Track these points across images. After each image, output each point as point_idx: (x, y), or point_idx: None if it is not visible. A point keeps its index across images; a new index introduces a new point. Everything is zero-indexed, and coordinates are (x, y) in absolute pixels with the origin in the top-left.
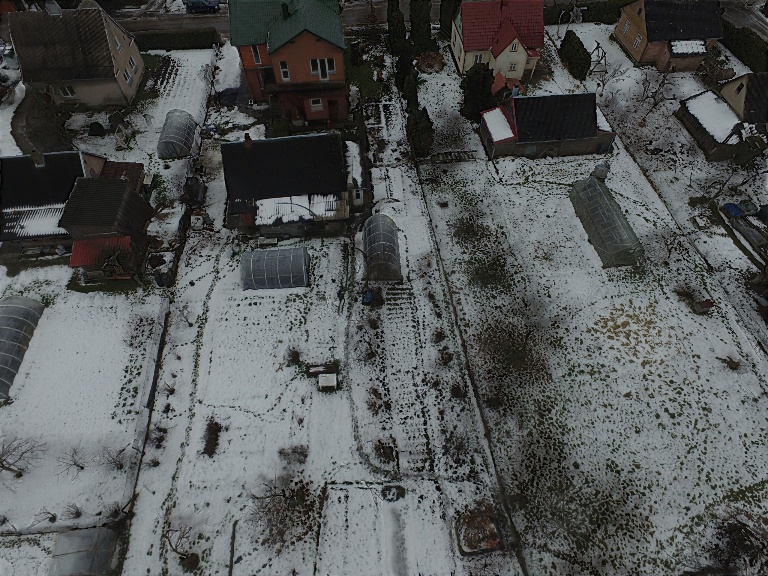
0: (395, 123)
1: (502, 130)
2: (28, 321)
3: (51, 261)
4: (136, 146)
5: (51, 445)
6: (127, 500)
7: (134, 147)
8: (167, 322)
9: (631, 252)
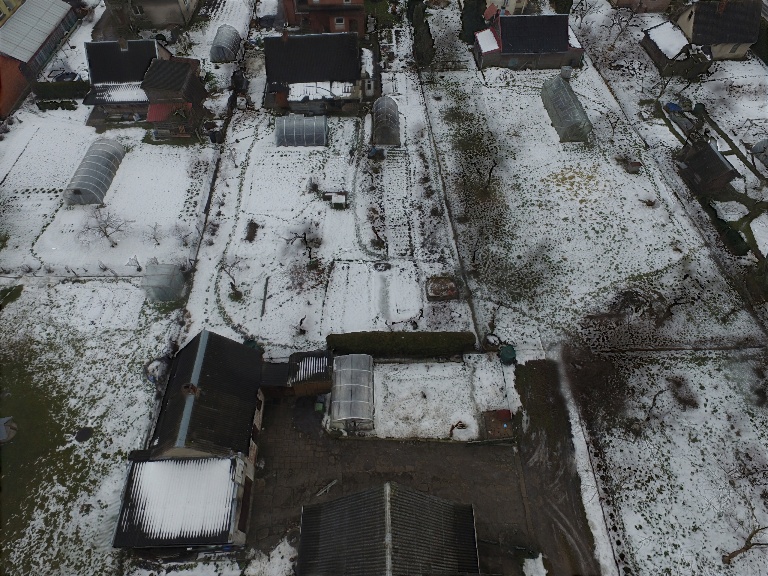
0: (404, 43)
1: (490, 44)
2: (116, 157)
3: (129, 125)
4: (192, 53)
5: (135, 231)
6: (192, 259)
7: (191, 54)
8: (218, 164)
9: (582, 127)
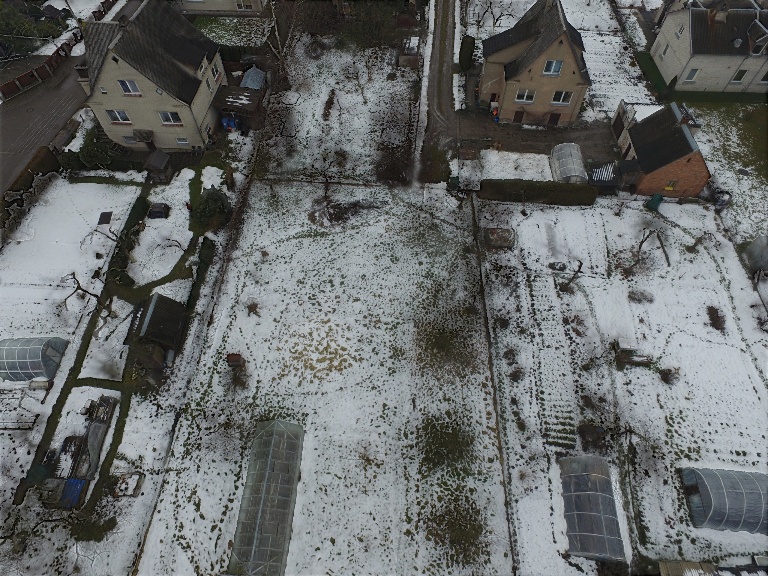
0: None
1: None
2: None
3: None
4: None
5: None
6: None
7: None
8: None
9: None
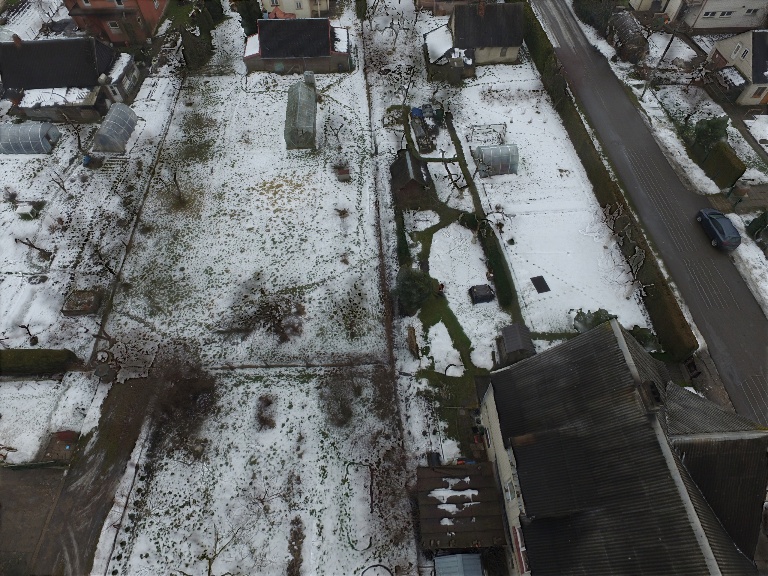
0: None
1: (253, 48)
2: None
3: None
4: None
5: None
6: None
7: None
8: None
9: (302, 134)
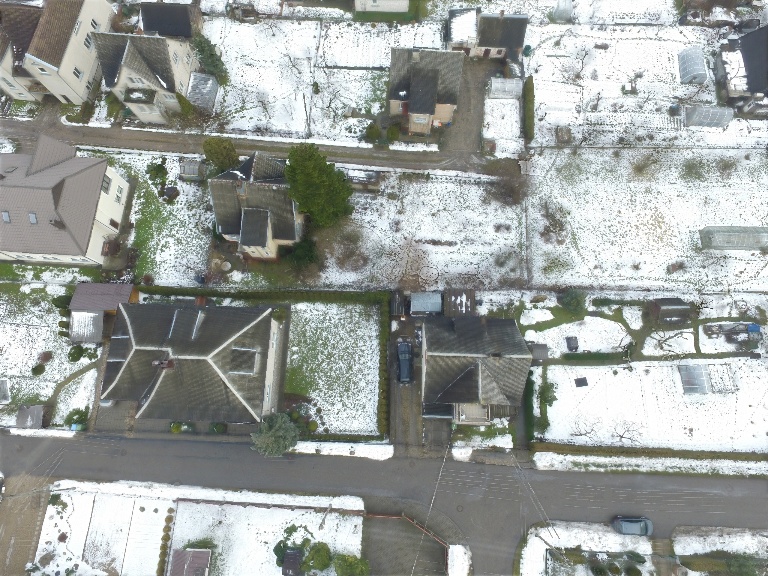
0: None
1: None
2: None
3: None
4: None
5: None
6: None
7: None
8: None
9: (710, 238)
